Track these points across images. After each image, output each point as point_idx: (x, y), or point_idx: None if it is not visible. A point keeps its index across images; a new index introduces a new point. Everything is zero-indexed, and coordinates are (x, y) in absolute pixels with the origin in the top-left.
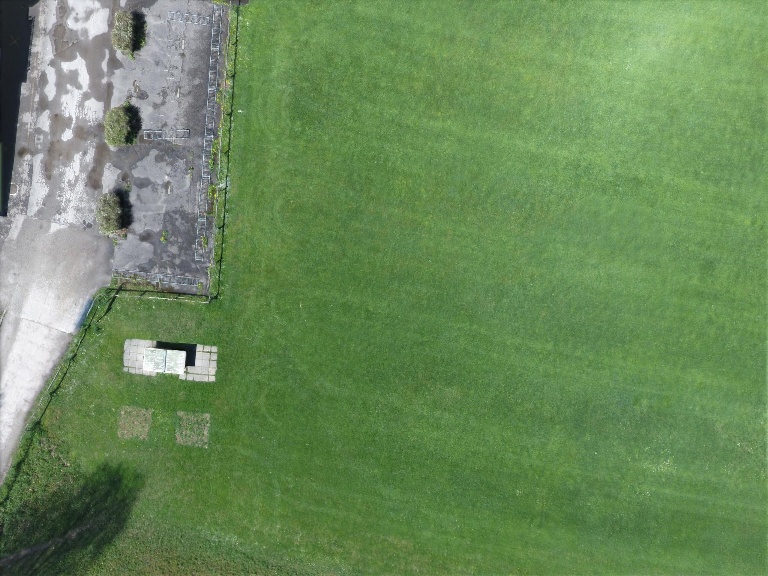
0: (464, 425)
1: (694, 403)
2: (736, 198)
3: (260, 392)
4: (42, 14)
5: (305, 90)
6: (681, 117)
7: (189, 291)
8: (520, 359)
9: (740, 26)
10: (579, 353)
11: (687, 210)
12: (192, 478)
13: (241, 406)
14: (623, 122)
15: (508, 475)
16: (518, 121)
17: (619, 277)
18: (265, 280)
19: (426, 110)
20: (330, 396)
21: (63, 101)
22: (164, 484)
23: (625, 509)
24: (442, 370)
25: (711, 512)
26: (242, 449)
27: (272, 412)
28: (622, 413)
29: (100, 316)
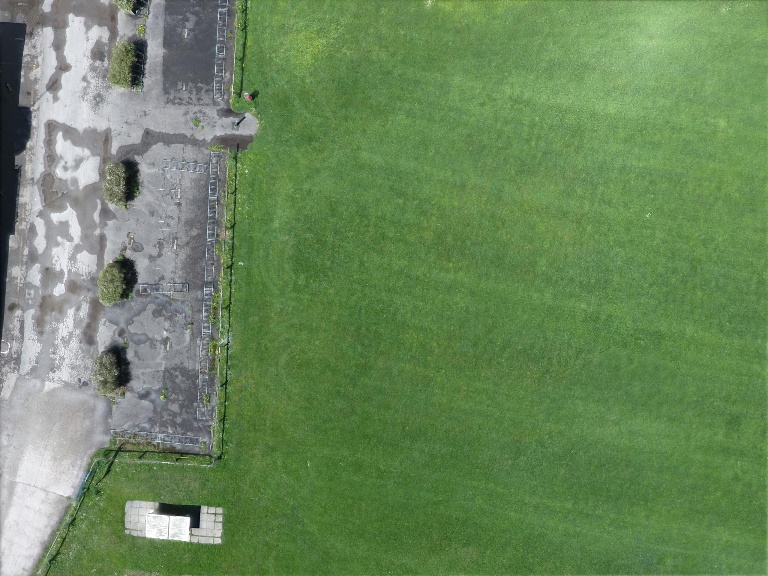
0: None
1: (720, 561)
2: (763, 351)
3: (268, 554)
4: (29, 163)
5: (309, 241)
6: (706, 267)
7: (191, 451)
8: (538, 518)
9: (767, 171)
10: (600, 511)
11: (712, 364)
12: None
13: (248, 568)
14: (644, 272)
15: None
16: (534, 272)
17: (641, 433)
18: (271, 438)
19: (437, 261)
20: (341, 557)
21: (54, 254)
22: None
23: None
24: (457, 529)
25: None
26: None
27: (281, 574)
28: (645, 572)
29: (99, 479)
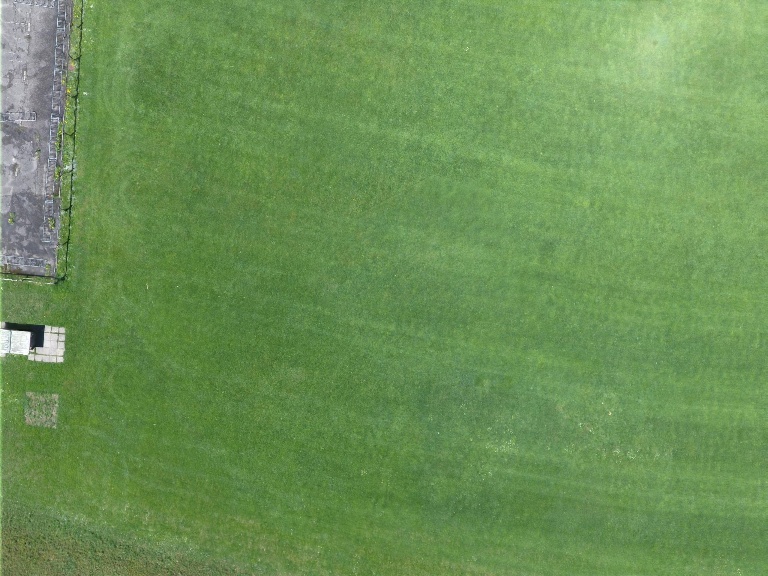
0: (309, 405)
1: (535, 383)
2: (575, 179)
3: (108, 373)
4: None
5: (149, 72)
6: (520, 98)
7: (37, 273)
8: (363, 340)
9: (578, 7)
10: (421, 334)
11: (526, 191)
12: (41, 458)
13: (89, 387)
14: (463, 104)
15: (352, 455)
16: (360, 103)
17: (460, 258)
18: (112, 262)
19: (269, 92)
20: (177, 377)
21: None
22: (14, 464)
23: (468, 489)
24: (287, 351)
25: (553, 492)
26: (91, 429)
27: (120, 393)
28: (464, 393)
29: None
